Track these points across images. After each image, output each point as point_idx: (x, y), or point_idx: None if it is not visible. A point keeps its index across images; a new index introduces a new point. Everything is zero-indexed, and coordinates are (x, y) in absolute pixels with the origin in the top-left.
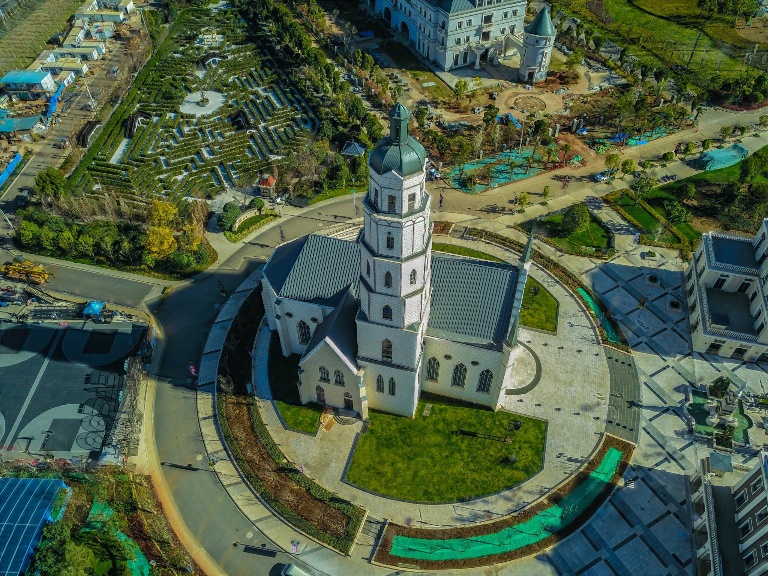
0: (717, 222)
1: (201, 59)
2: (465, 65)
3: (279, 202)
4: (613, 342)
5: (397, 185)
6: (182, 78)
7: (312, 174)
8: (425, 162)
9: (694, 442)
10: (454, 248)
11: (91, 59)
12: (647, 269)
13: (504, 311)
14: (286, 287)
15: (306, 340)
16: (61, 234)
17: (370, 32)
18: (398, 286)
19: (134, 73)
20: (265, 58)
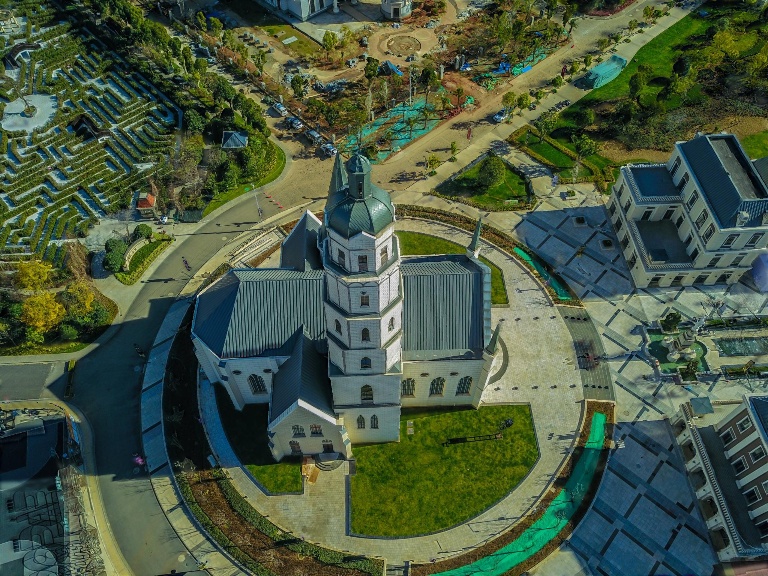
0: (619, 144)
1: (7, 55)
2: (323, 10)
3: (167, 222)
4: (564, 299)
5: (369, 245)
6: None
7: (197, 182)
8: None
9: (663, 383)
10: None
11: None
12: (571, 210)
13: (475, 316)
14: (228, 346)
15: (259, 389)
16: None
17: None
18: (377, 339)
19: None
20: (88, 39)
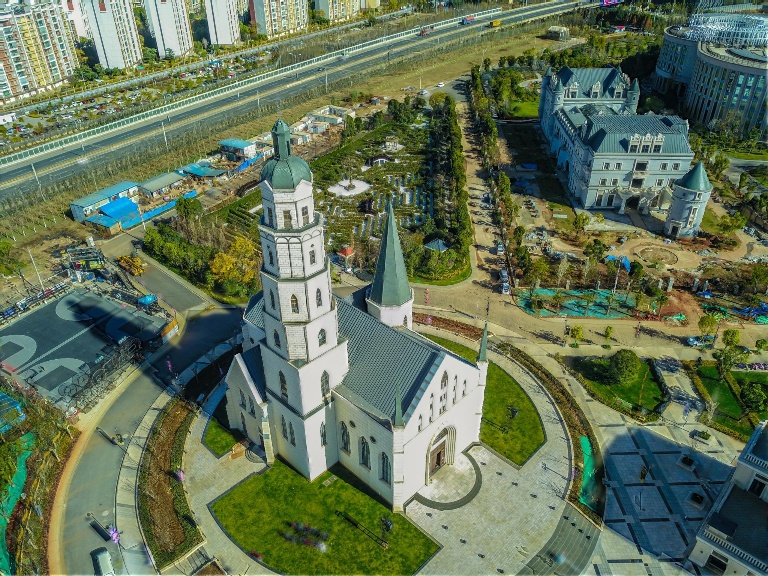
0: None
1: (372, 157)
2: (609, 208)
3: (349, 272)
4: (582, 503)
5: (270, 197)
6: None
7: None
8: (302, 183)
9: None
10: (473, 353)
11: (295, 144)
12: (689, 449)
13: (412, 391)
14: (253, 312)
15: None
16: (166, 243)
17: (534, 165)
18: (279, 308)
19: (316, 158)
20: (425, 167)
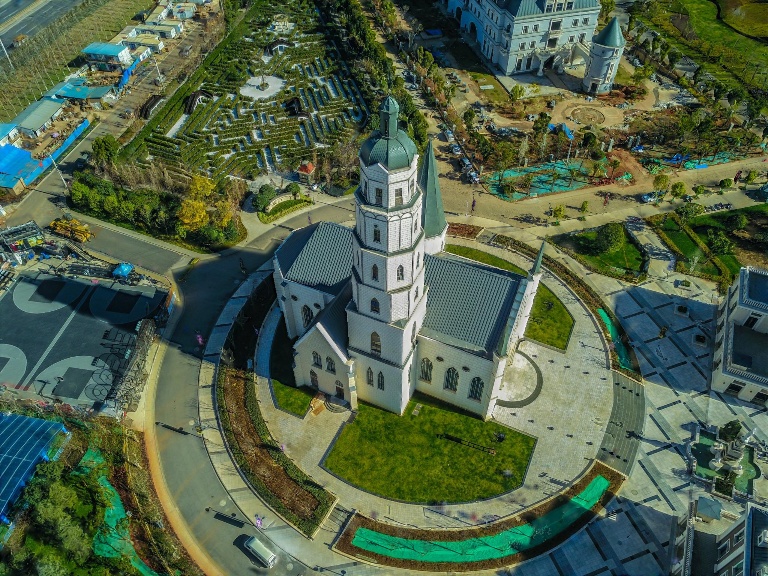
0: (767, 258)
1: (269, 45)
2: (528, 71)
3: (315, 189)
4: (624, 368)
5: (383, 178)
6: (248, 62)
7: (350, 165)
8: (414, 158)
9: (691, 484)
10: (478, 253)
11: (169, 37)
12: (678, 298)
13: (500, 320)
14: (293, 270)
15: None
16: (107, 198)
17: (438, 31)
18: (384, 280)
19: (205, 53)
20: (330, 48)
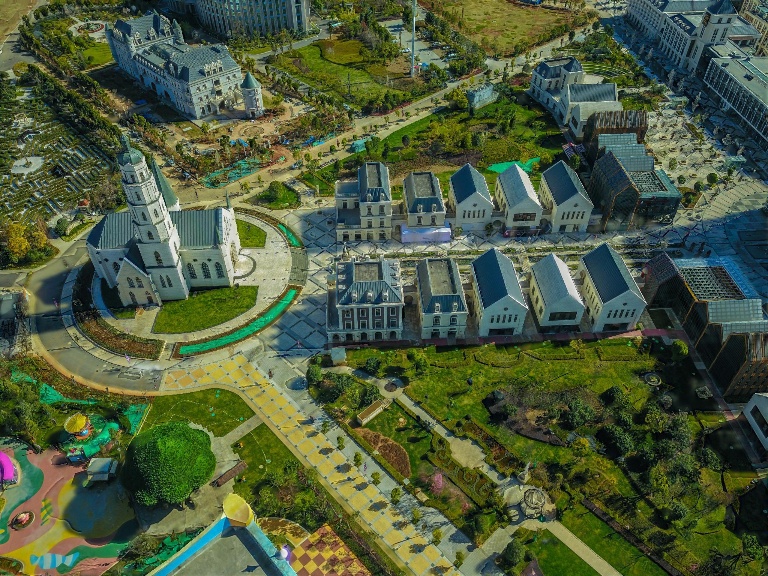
0: None
1: (19, 136)
2: (211, 113)
3: (94, 215)
4: (295, 245)
5: (132, 169)
6: (8, 151)
7: (112, 193)
8: (143, 158)
9: None
10: None
11: None
12: (318, 209)
13: None
14: (101, 244)
15: None
16: None
17: (143, 101)
18: (150, 219)
19: None
20: (68, 129)
